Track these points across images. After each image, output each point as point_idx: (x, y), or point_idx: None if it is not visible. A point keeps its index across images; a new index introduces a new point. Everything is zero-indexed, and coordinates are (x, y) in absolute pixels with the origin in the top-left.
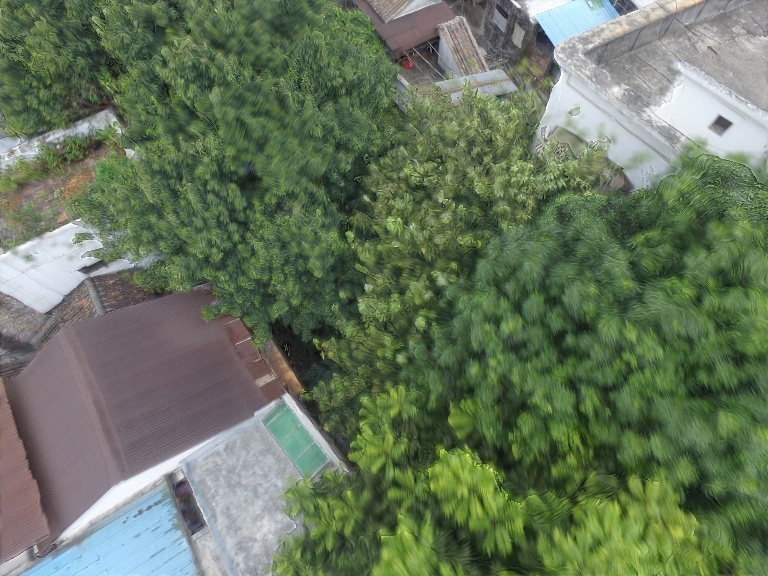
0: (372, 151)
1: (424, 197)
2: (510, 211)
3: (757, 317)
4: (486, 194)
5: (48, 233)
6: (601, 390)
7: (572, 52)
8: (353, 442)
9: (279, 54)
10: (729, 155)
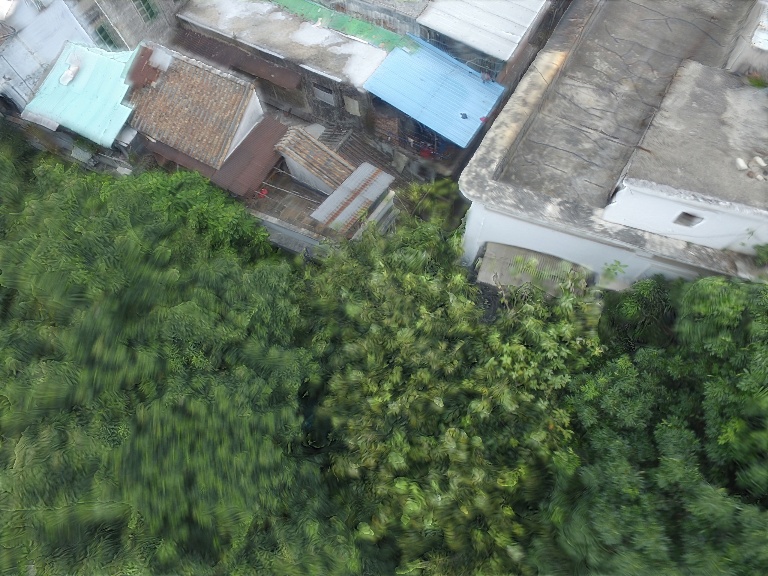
0: (315, 379)
1: None
2: None
3: None
4: None
5: None
6: None
7: (480, 183)
8: None
9: (149, 353)
10: (704, 239)
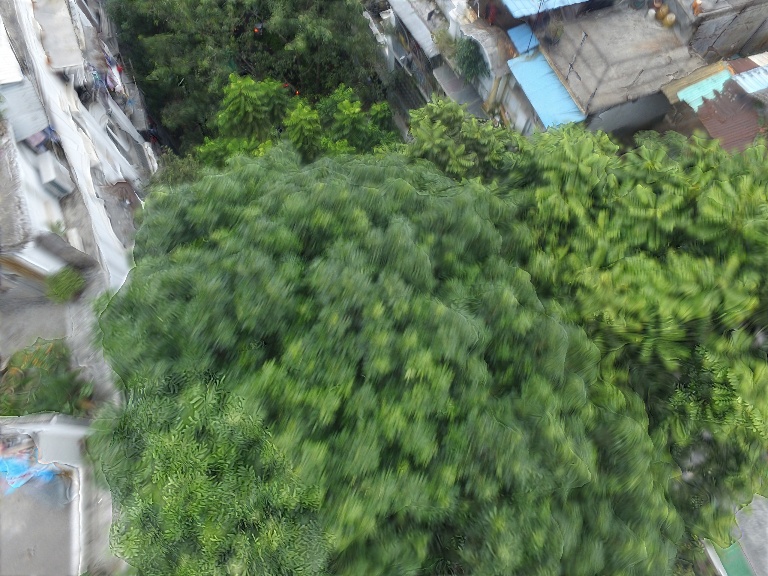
0: None
1: None
2: None
3: (416, 407)
4: None
5: None
6: (582, 418)
7: None
8: None
9: None
10: None
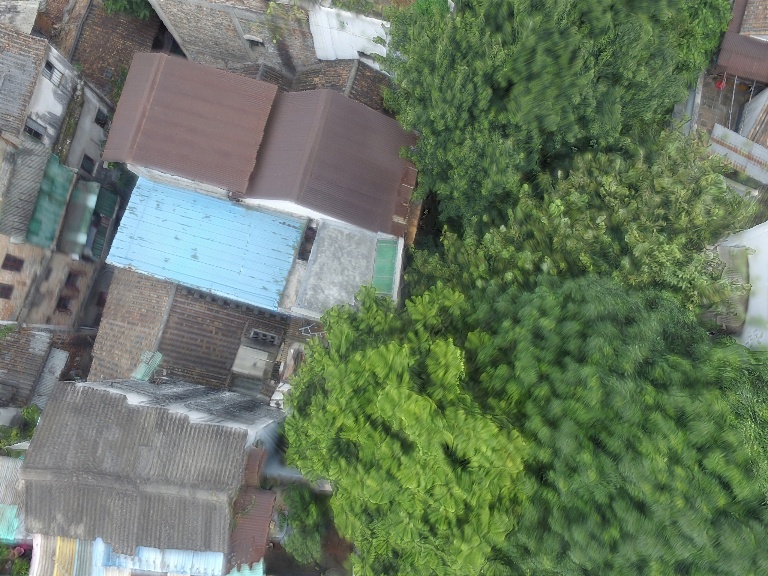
0: (600, 143)
1: (597, 206)
2: (632, 269)
3: (661, 441)
4: (631, 244)
5: (363, 16)
6: (550, 392)
7: None
8: (414, 297)
9: (608, 21)
10: None
